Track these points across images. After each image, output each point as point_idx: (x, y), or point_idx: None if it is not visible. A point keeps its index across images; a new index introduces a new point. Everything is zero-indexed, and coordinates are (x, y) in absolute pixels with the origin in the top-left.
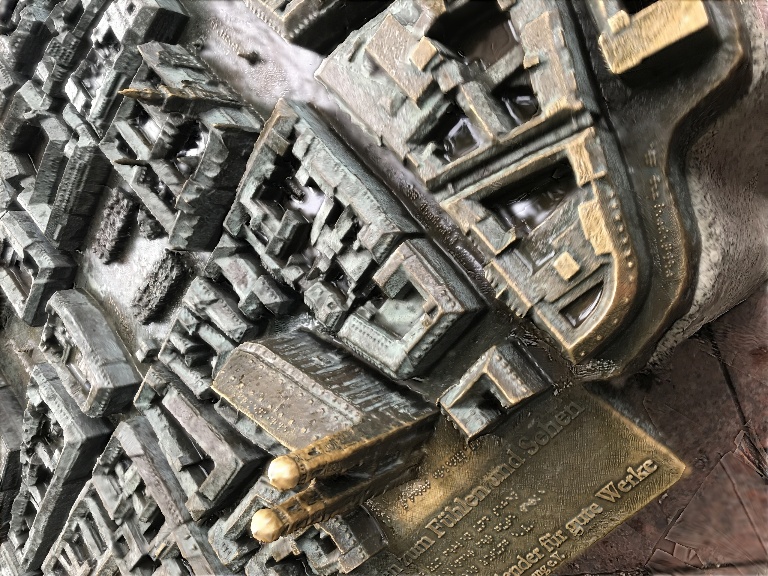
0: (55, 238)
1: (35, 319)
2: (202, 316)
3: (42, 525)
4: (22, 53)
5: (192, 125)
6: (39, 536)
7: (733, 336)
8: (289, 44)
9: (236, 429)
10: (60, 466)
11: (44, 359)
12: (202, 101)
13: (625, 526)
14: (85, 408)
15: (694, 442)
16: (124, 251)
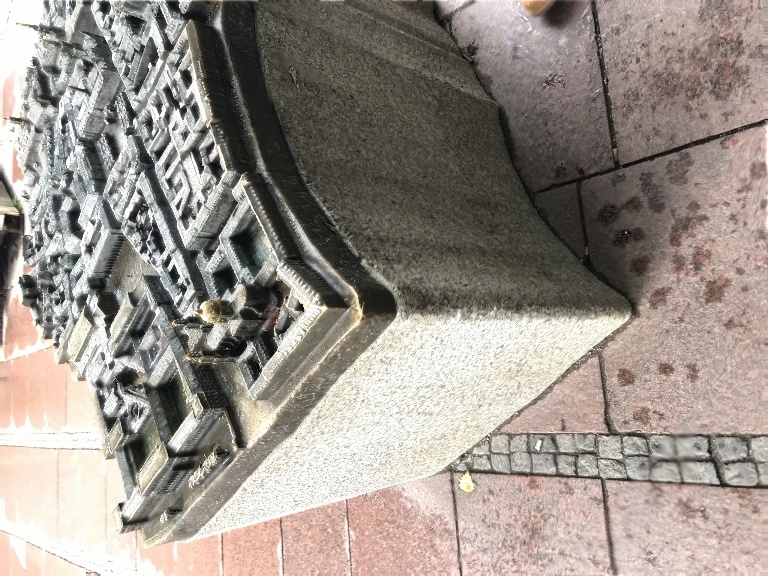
0: (94, 190)
1: (111, 225)
2: (121, 53)
3: (172, 243)
4: (56, 210)
5: (88, 65)
6: (178, 255)
7: (452, 1)
8: (84, 6)
9: (149, 28)
10: (146, 196)
11: (139, 258)
12: (78, 45)
13: (562, 52)
14: (130, 157)
15: (507, 12)
16: (118, 152)
